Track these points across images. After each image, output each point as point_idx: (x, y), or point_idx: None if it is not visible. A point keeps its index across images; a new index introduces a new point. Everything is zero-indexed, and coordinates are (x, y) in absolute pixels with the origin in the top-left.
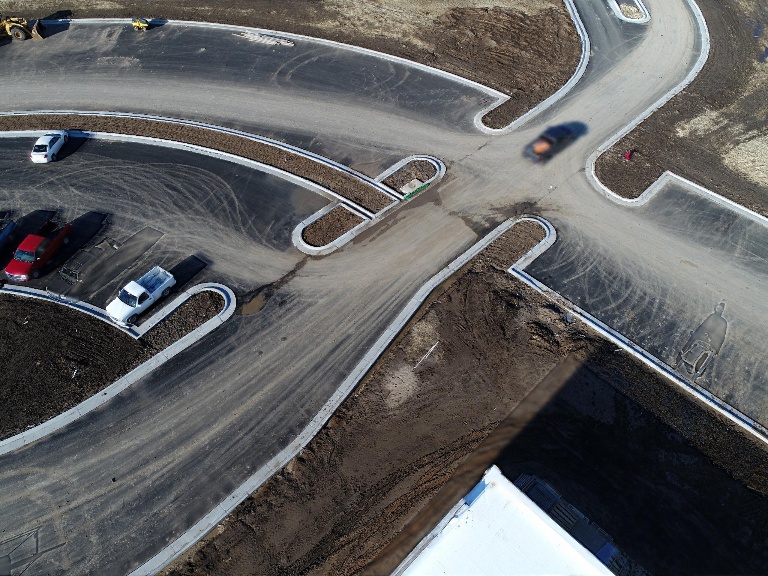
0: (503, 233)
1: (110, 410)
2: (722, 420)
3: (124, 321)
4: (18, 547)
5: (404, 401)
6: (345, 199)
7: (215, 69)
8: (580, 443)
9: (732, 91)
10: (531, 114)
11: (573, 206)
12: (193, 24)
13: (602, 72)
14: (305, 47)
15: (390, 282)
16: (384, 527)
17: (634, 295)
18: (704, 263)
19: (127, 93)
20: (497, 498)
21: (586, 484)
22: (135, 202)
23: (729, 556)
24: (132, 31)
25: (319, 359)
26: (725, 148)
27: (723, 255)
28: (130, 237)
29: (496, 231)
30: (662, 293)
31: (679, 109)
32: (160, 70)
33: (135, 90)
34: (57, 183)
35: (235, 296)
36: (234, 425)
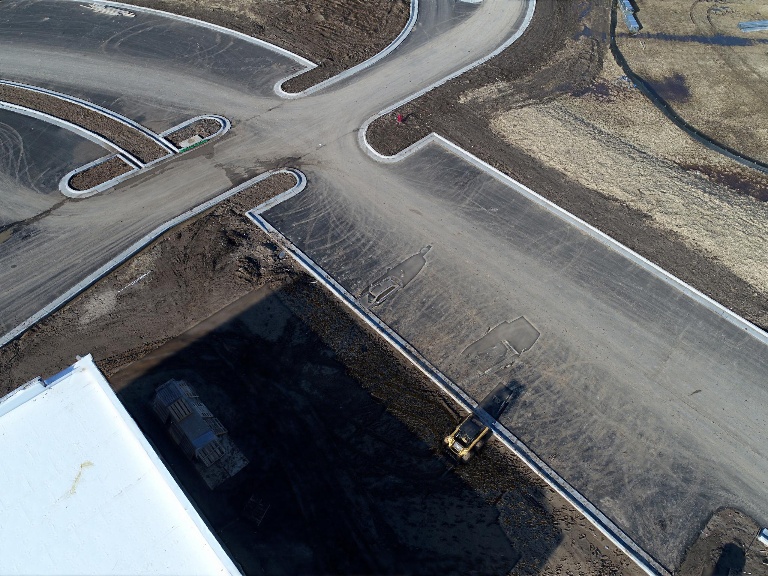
0: (256, 183)
1: None
2: (379, 341)
3: None
4: None
5: (96, 318)
6: (123, 151)
7: (51, 36)
8: (238, 356)
9: (532, 65)
10: (331, 81)
11: (333, 161)
12: None
13: (416, 45)
14: (144, 18)
15: (133, 222)
16: None
17: (352, 237)
18: (429, 212)
19: None
20: (81, 380)
21: (226, 388)
22: None
23: (325, 448)
24: None
25: (38, 283)
26: (495, 113)
27: (450, 205)
28: None
29: (251, 181)
30: (379, 236)
31: (471, 79)
32: None
33: None
34: None
35: None
36: None
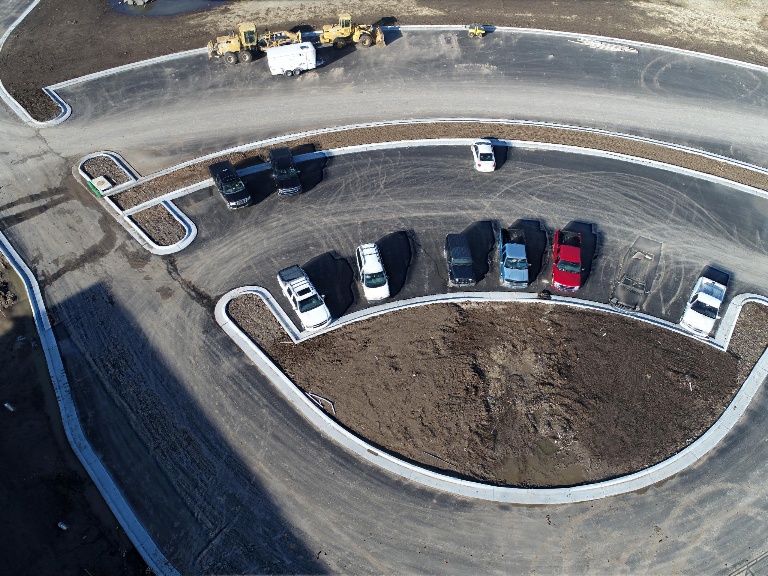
0: None
1: (753, 424)
2: None
3: (708, 333)
4: None
5: None
6: None
7: (578, 76)
8: None
9: None
10: None
11: None
12: (523, 31)
13: None
14: (650, 54)
15: None
16: None
17: None
18: None
19: (510, 101)
20: None
21: None
22: (607, 211)
23: None
24: (468, 38)
25: None
26: None
27: None
28: (632, 247)
29: None
30: None
31: None
32: (525, 77)
33: (516, 97)
34: (515, 192)
35: None
36: None
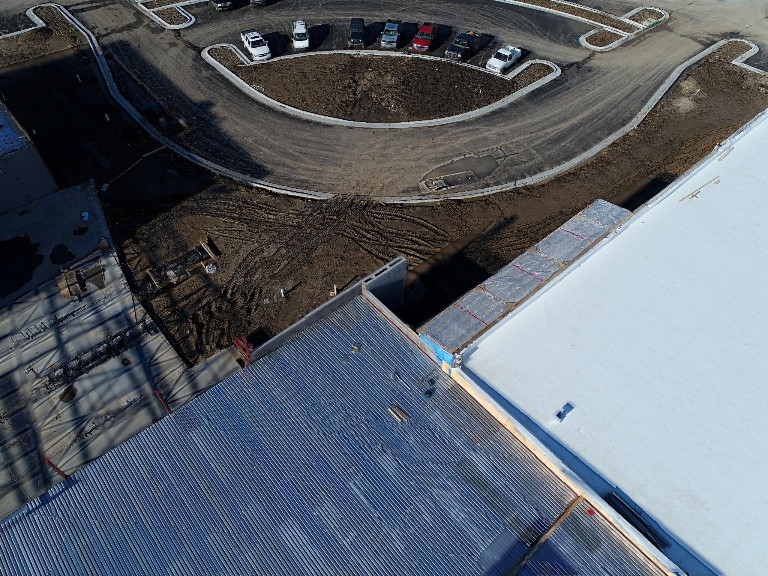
0: (722, 46)
1: (510, 108)
2: None
3: (500, 69)
4: (494, 153)
5: (690, 110)
6: (607, 26)
7: None
8: None
9: None
10: None
11: (766, 35)
12: None
13: None
14: None
15: (655, 64)
16: (700, 154)
17: None
18: None
19: None
20: None
21: None
22: (466, 21)
23: None
24: None
25: (626, 94)
26: None
27: None
28: None
29: (716, 45)
30: None
31: None
32: None
33: None
34: (408, 10)
35: (558, 66)
36: (589, 117)
